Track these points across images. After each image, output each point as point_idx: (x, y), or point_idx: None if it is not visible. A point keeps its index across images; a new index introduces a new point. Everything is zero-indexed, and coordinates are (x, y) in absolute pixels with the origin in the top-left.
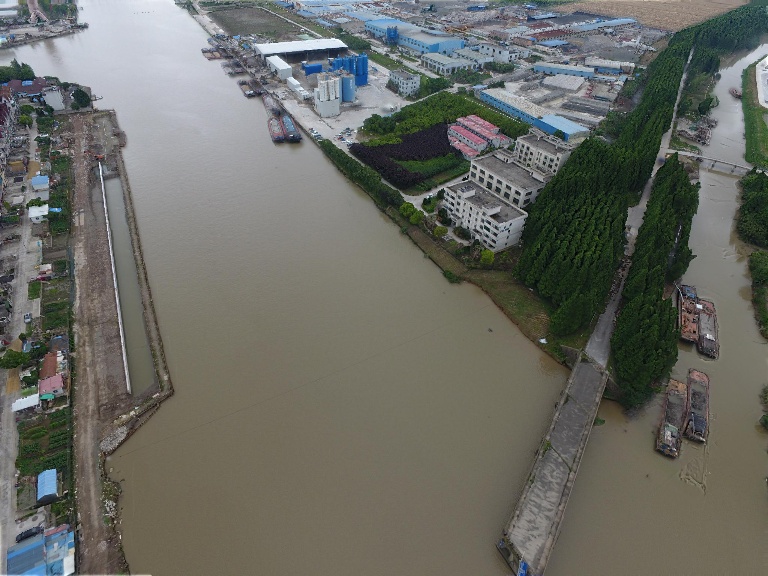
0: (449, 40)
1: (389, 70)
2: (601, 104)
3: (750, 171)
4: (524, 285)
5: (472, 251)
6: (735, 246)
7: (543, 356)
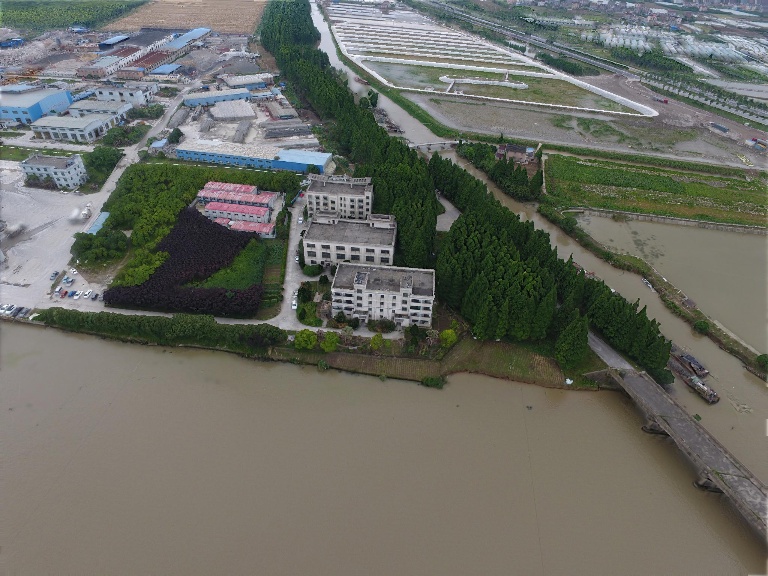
0: (49, 95)
1: None
2: (294, 123)
3: (458, 144)
4: (490, 340)
5: None
6: None
7: (582, 395)
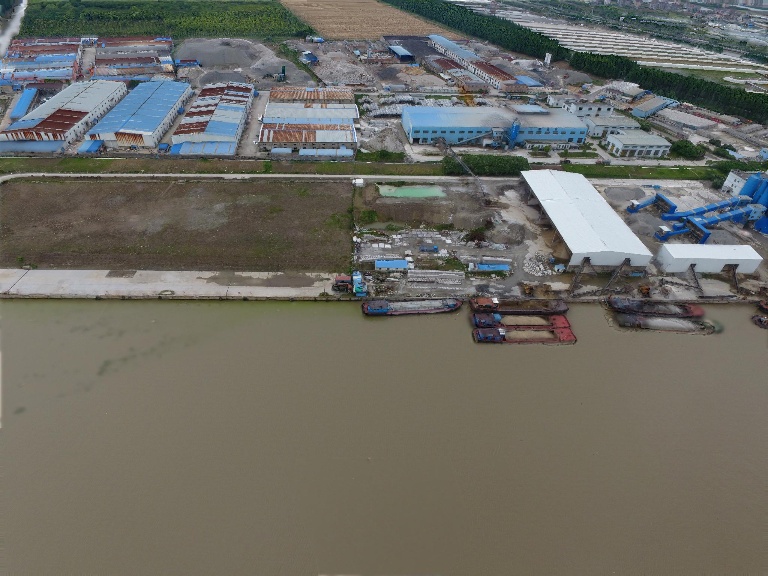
0: None
1: (649, 179)
2: (759, 128)
3: None
4: None
5: None
6: None
7: None
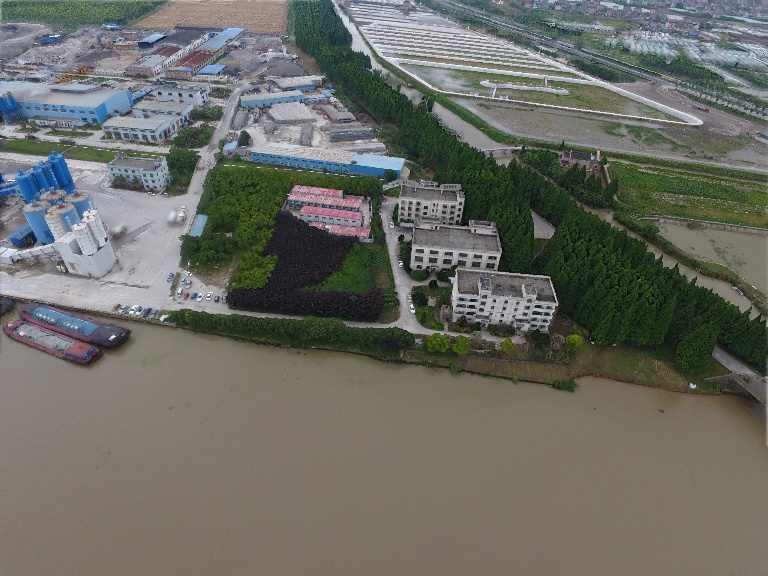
0: (112, 95)
1: (72, 160)
2: (355, 126)
3: (521, 150)
4: (607, 345)
5: None
6: None
7: (706, 399)
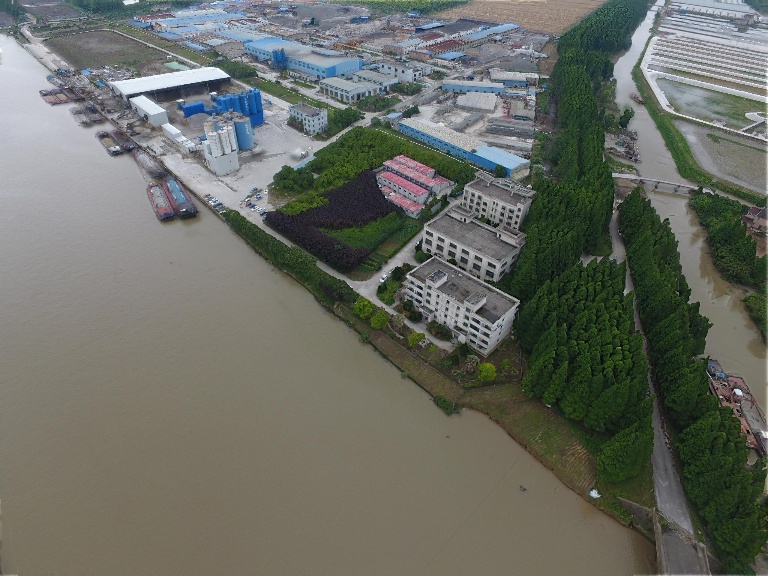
0: (345, 61)
1: (285, 102)
2: (524, 124)
3: (696, 191)
4: (538, 401)
5: (460, 358)
6: (708, 279)
7: (601, 518)
